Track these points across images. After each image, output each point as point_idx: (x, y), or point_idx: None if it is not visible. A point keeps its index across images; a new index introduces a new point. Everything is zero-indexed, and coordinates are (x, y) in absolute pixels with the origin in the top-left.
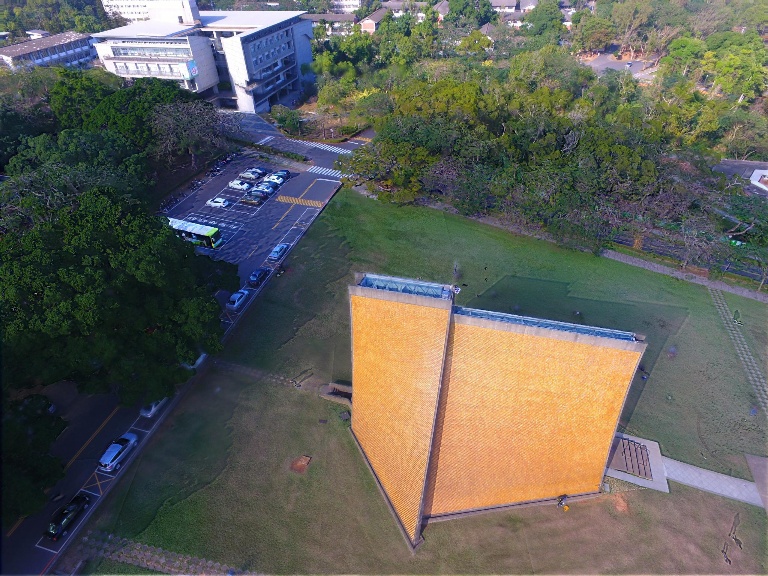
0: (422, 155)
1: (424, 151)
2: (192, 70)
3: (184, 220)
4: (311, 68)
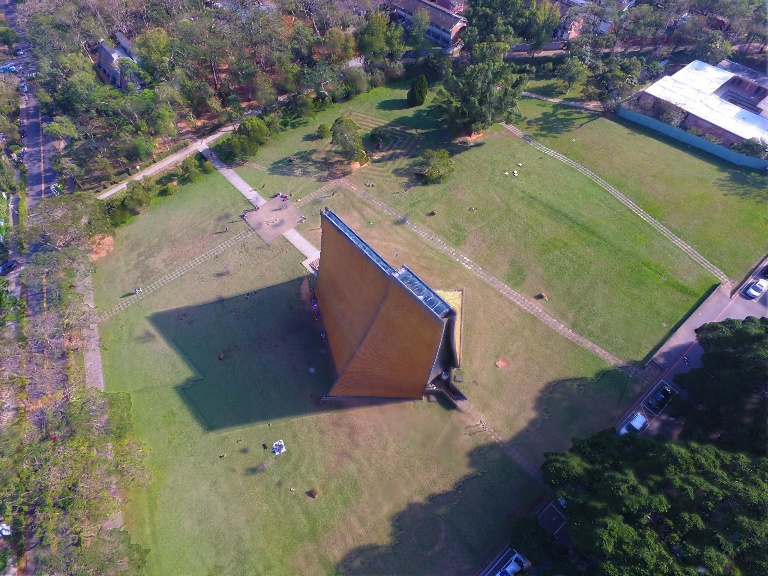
0: None
1: None
2: None
3: None
4: None
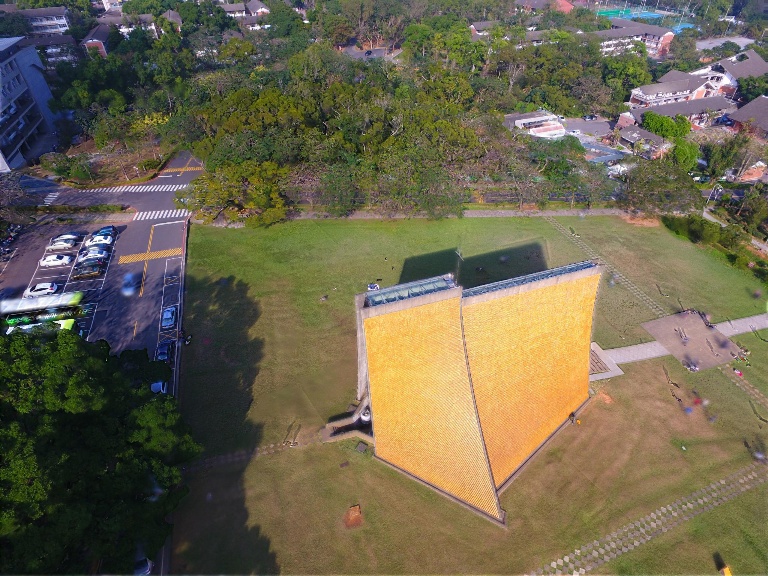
0: (272, 169)
1: (273, 165)
2: None
3: None
4: (64, 103)
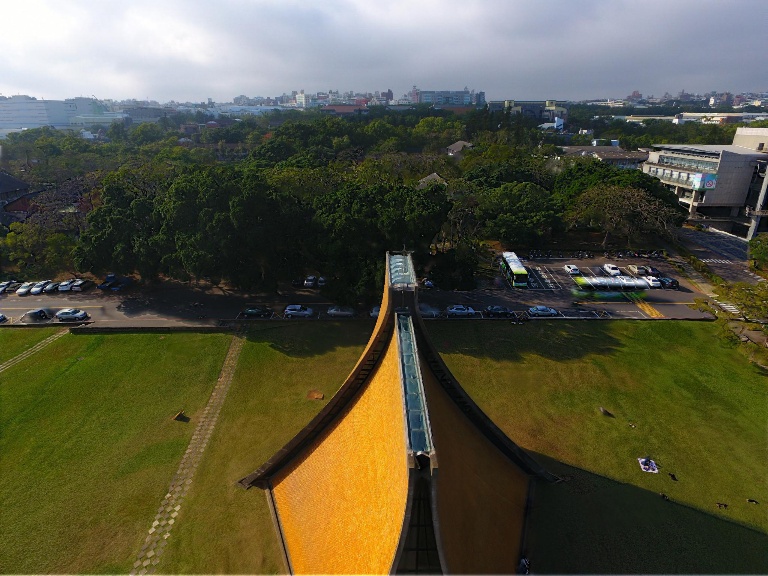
0: None
1: None
2: (708, 183)
3: (531, 266)
4: None
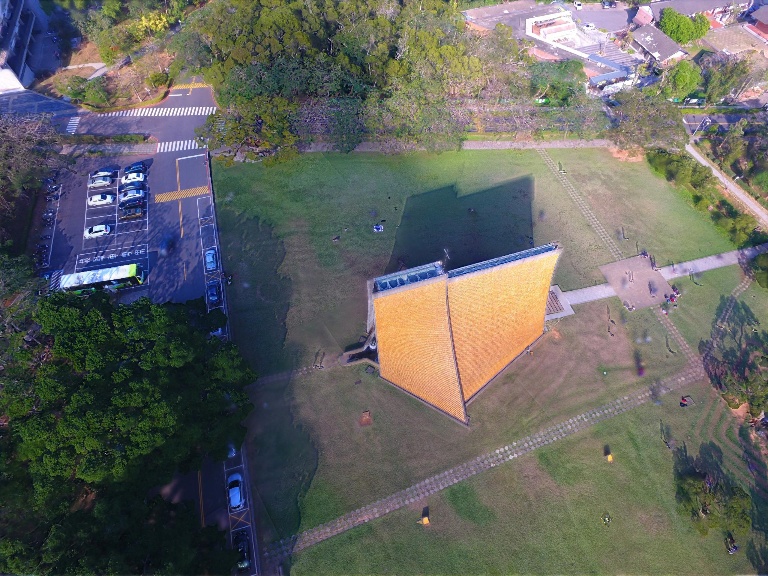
0: (283, 106)
1: (284, 101)
2: None
3: (77, 267)
4: (57, 4)
